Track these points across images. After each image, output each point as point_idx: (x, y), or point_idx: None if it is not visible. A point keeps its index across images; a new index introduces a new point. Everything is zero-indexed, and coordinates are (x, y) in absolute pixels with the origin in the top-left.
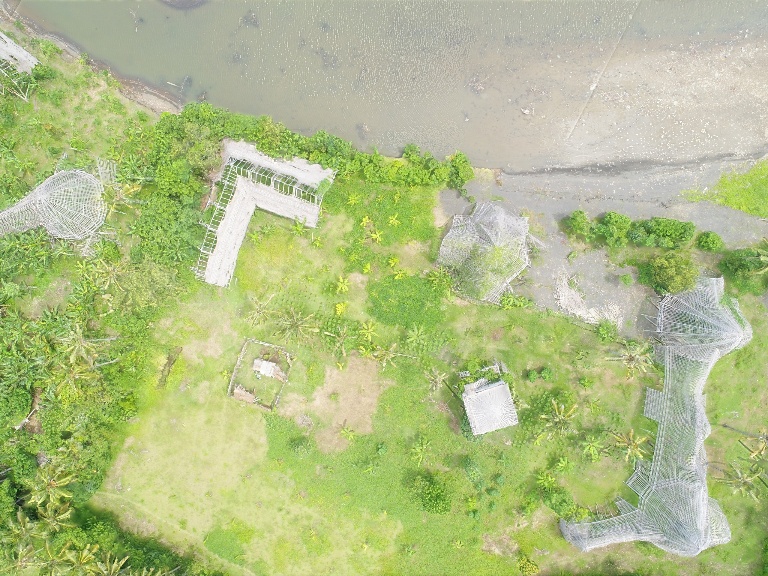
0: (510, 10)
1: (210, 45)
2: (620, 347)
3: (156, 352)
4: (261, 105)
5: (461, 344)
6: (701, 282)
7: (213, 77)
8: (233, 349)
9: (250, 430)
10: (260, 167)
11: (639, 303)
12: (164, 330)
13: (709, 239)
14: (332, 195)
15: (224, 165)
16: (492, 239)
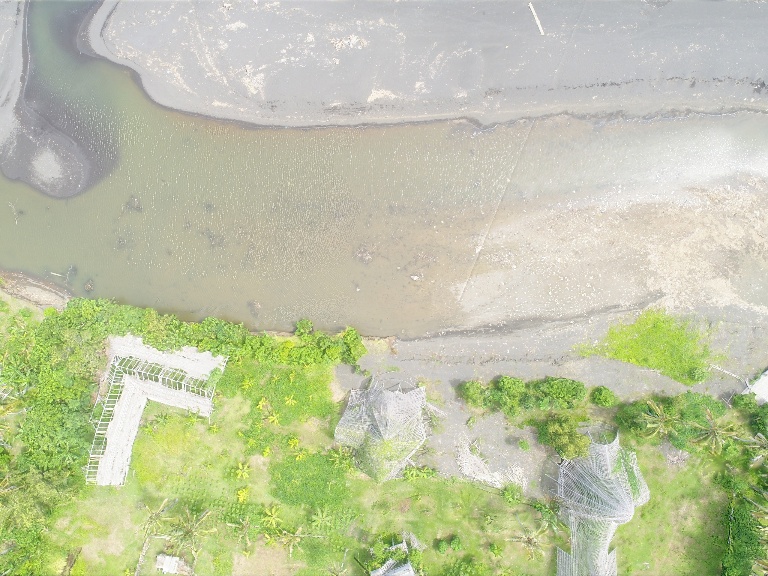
0: (391, 180)
1: (94, 232)
2: (527, 508)
3: (53, 556)
4: (150, 289)
5: (369, 519)
6: (594, 449)
7: (99, 264)
8: (135, 544)
9: None
10: (147, 363)
11: (541, 463)
12: (61, 531)
13: (601, 397)
14: (226, 378)
15: (110, 364)
16: (381, 431)
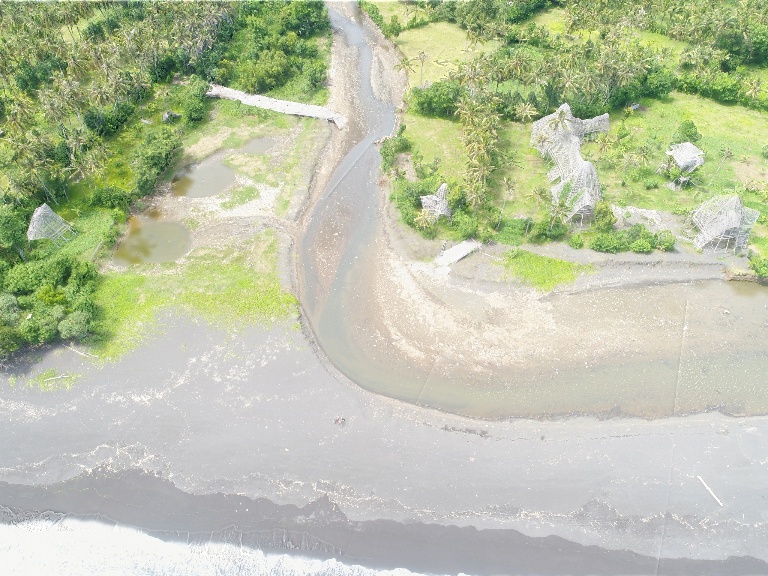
0: None
1: None
2: None
3: None
4: None
5: (702, 196)
6: None
7: None
8: None
9: None
10: None
11: None
12: None
13: None
14: None
15: None
16: None
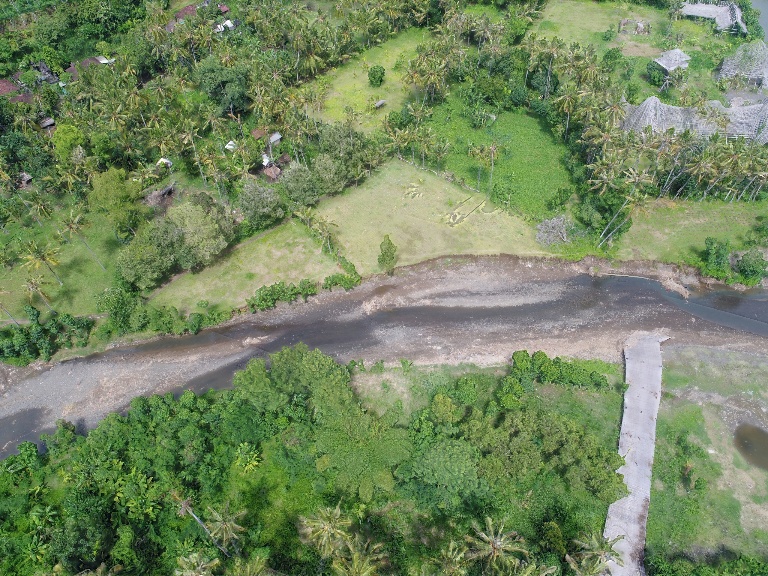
0: None
1: None
2: None
3: (629, 4)
4: None
5: None
6: None
7: None
8: None
9: (605, 28)
10: None
11: None
12: None
13: None
14: None
15: None
16: None
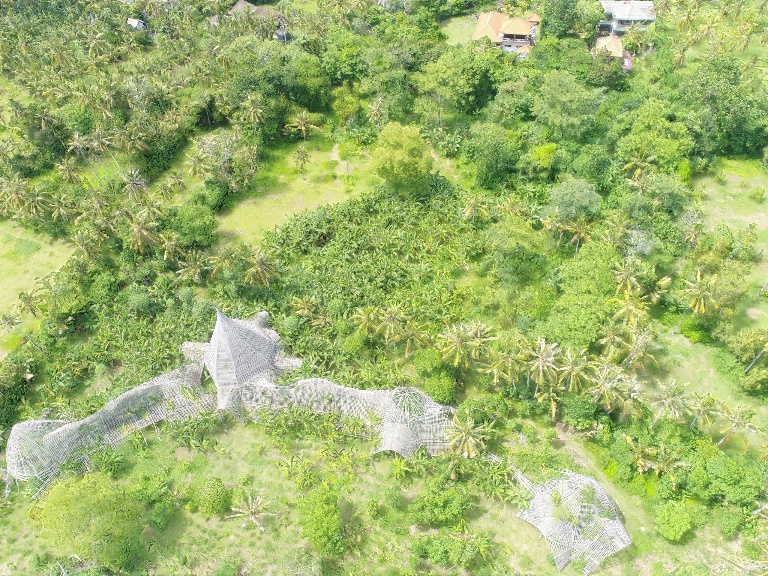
0: None
1: None
2: None
3: None
4: None
5: None
6: None
7: None
8: None
9: None
10: None
11: None
12: None
13: None
14: None
15: None
16: None
